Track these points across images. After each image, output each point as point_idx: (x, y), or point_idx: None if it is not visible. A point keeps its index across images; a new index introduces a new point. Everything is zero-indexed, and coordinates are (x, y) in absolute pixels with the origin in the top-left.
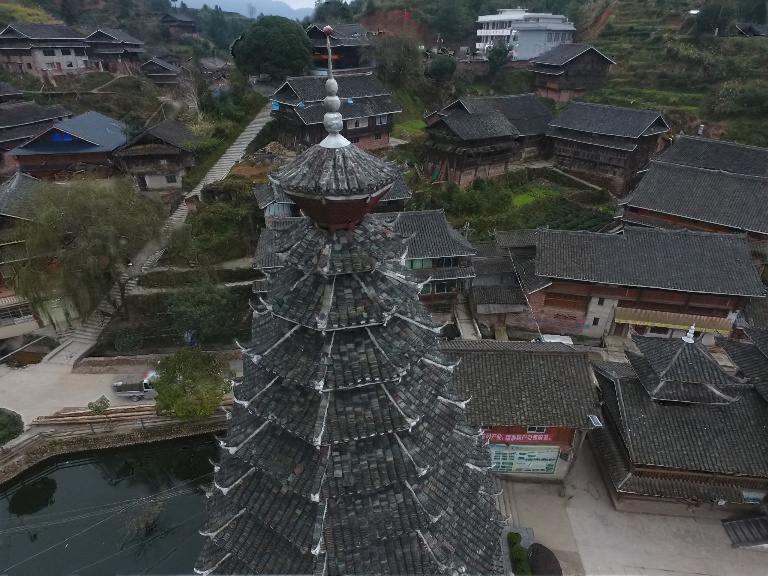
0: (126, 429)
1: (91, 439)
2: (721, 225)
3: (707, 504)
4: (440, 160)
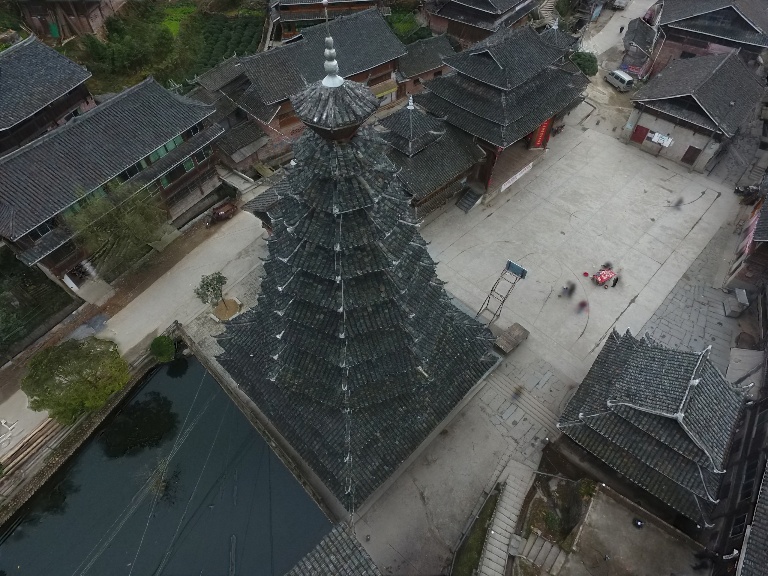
0: (37, 466)
1: (9, 503)
2: (353, 2)
3: (447, 200)
4: (47, 9)
